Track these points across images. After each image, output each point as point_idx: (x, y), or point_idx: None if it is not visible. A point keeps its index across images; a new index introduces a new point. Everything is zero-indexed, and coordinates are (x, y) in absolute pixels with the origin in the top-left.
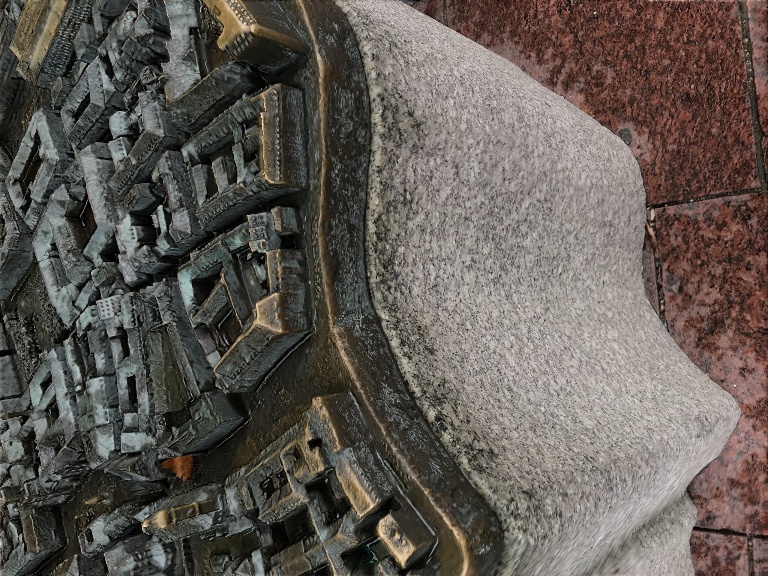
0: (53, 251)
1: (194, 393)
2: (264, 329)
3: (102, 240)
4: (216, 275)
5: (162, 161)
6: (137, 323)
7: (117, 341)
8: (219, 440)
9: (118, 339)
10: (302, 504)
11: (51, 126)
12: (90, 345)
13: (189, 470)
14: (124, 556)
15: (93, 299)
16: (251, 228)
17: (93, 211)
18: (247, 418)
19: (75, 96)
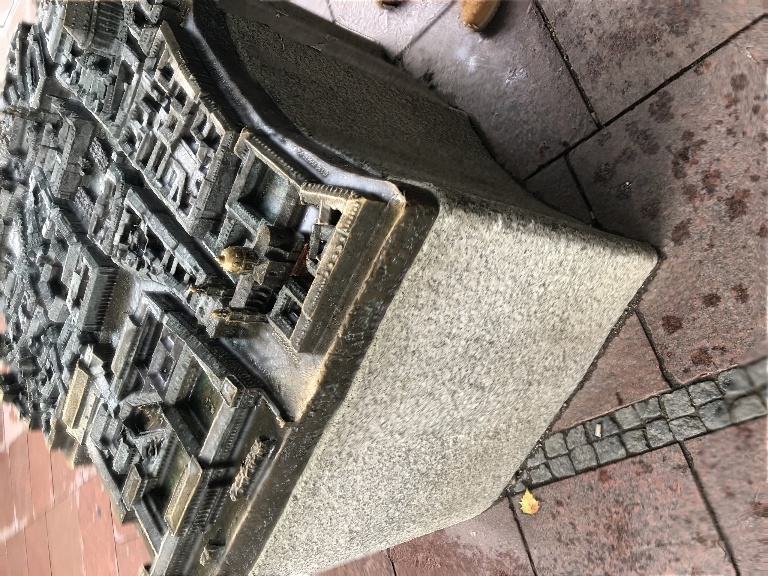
0: None
1: None
2: None
3: None
4: None
5: None
6: None
7: None
8: None
9: None
10: None
11: None
12: None
13: None
14: (14, 158)
15: None
16: None
17: None
18: None
19: None
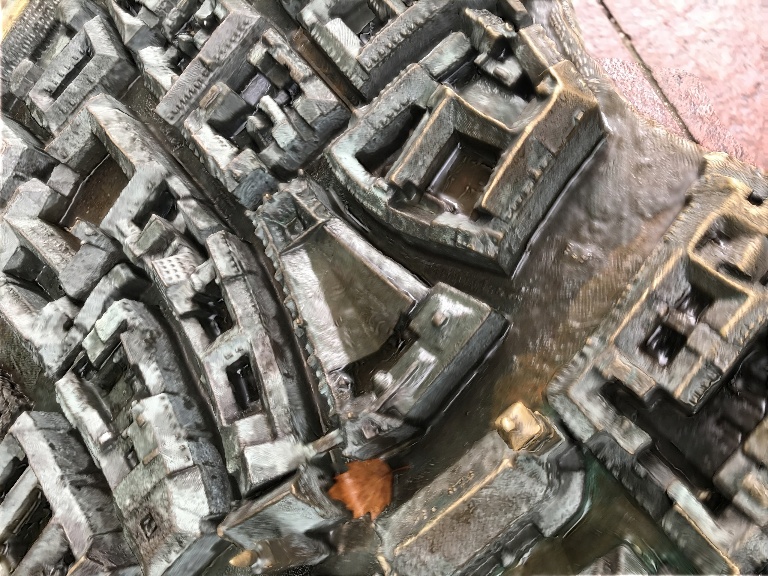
0: (10, 277)
1: (416, 292)
2: (571, 100)
3: (140, 195)
4: (383, 153)
5: (269, 34)
6: (240, 269)
7: (193, 321)
8: (450, 392)
9: (193, 318)
10: (765, 320)
11: (5, 122)
12: (129, 352)
13: (383, 489)
14: None
15: (109, 306)
16: (481, 16)
17: (126, 154)
18: (506, 324)
19: (58, 67)
